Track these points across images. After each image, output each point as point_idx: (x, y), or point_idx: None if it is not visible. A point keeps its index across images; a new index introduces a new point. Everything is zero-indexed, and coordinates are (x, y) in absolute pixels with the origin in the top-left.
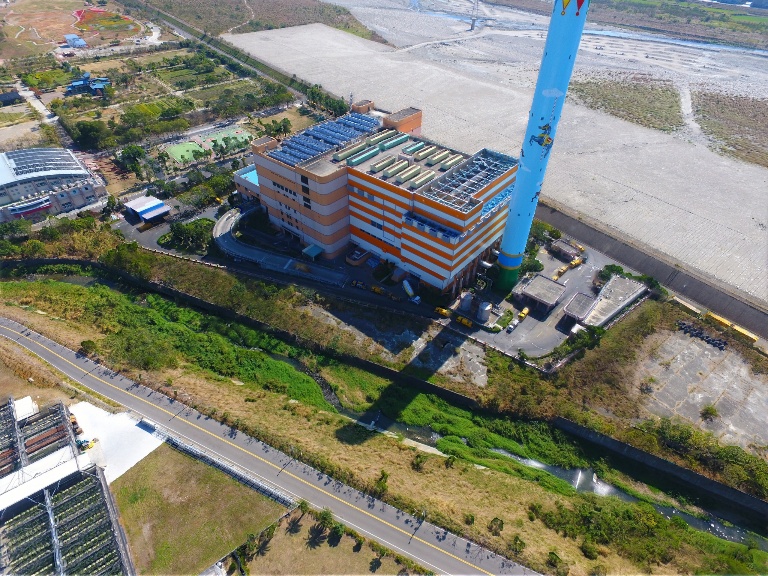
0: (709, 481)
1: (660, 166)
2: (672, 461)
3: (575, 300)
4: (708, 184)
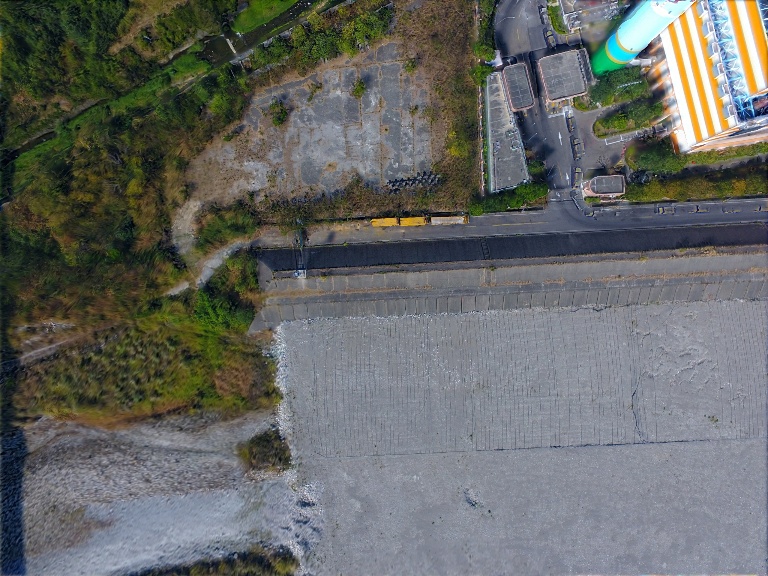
0: (326, 12)
1: (673, 568)
2: (353, 6)
3: (528, 89)
4: (586, 569)
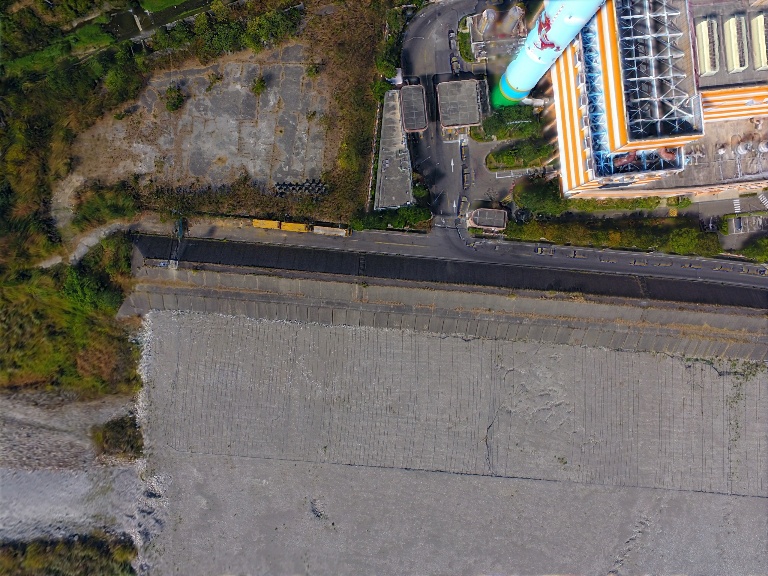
0: (234, 4)
1: None
2: (263, 1)
3: (423, 112)
4: None
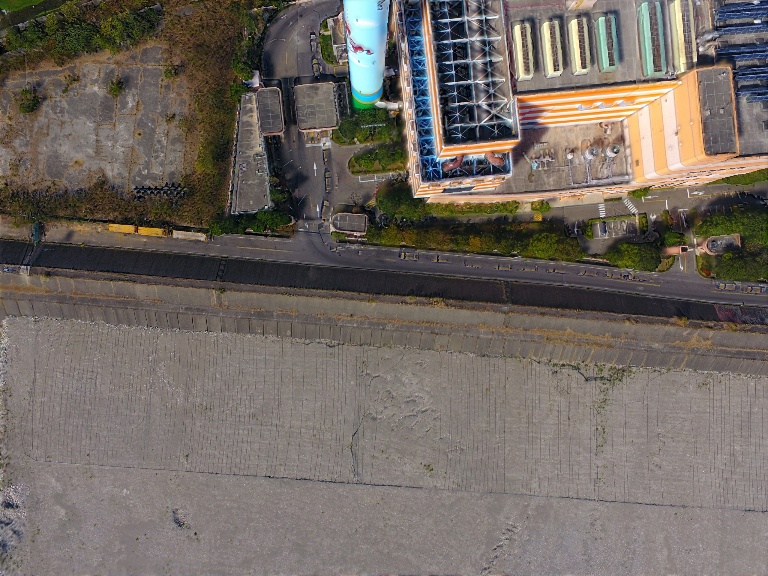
0: (89, 4)
1: None
2: (119, 1)
3: (279, 115)
4: None
